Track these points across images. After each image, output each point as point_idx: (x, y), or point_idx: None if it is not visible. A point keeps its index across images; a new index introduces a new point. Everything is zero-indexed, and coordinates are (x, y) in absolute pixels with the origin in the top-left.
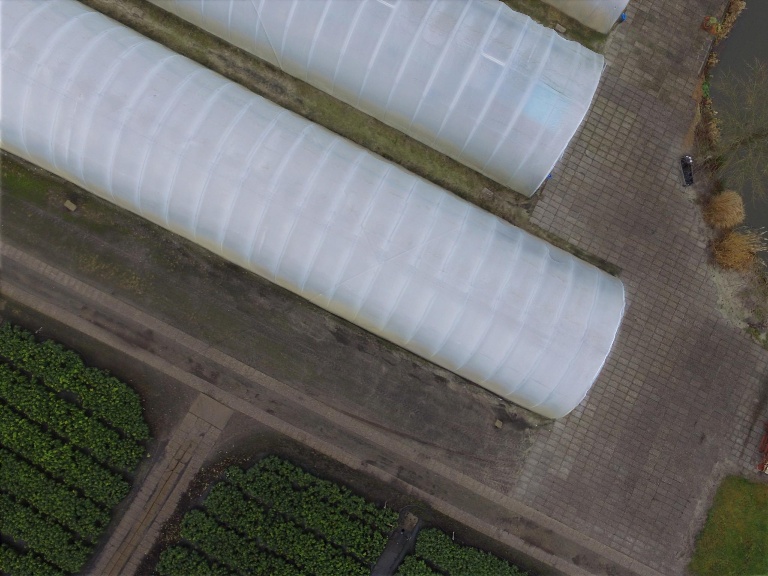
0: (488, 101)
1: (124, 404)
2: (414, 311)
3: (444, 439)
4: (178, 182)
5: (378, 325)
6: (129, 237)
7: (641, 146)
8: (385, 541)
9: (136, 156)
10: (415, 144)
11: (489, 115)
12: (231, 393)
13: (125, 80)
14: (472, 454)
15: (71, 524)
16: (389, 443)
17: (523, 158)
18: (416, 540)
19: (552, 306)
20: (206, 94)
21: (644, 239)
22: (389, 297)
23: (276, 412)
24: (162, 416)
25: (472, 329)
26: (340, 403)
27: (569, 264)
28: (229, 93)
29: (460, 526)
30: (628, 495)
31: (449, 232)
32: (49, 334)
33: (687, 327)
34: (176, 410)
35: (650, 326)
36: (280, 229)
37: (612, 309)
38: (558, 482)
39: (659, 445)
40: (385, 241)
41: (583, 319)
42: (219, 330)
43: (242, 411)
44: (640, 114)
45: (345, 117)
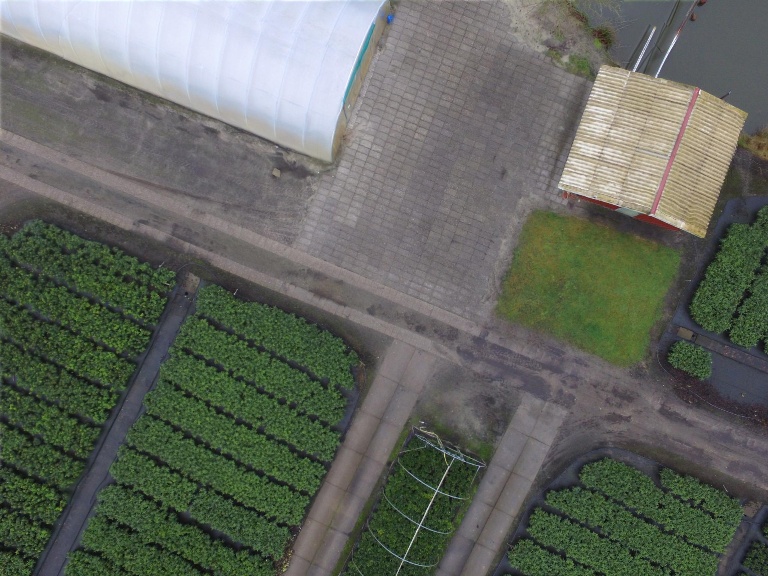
0: None
1: None
2: (147, 34)
3: (218, 192)
4: None
5: (124, 65)
6: None
7: None
8: (163, 301)
9: None
10: None
11: None
12: None
13: None
14: (250, 206)
15: None
16: (160, 200)
17: None
18: (196, 298)
19: (292, 12)
20: None
21: None
22: (118, 20)
23: (39, 176)
24: None
25: (209, 47)
26: (105, 162)
27: None
28: None
29: (243, 282)
30: (424, 239)
31: None
32: None
33: (478, 55)
34: None
35: (436, 57)
36: None
37: (364, 14)
38: (346, 230)
39: (455, 184)
40: None
41: (327, 23)
42: None
43: (4, 178)
44: None
45: None
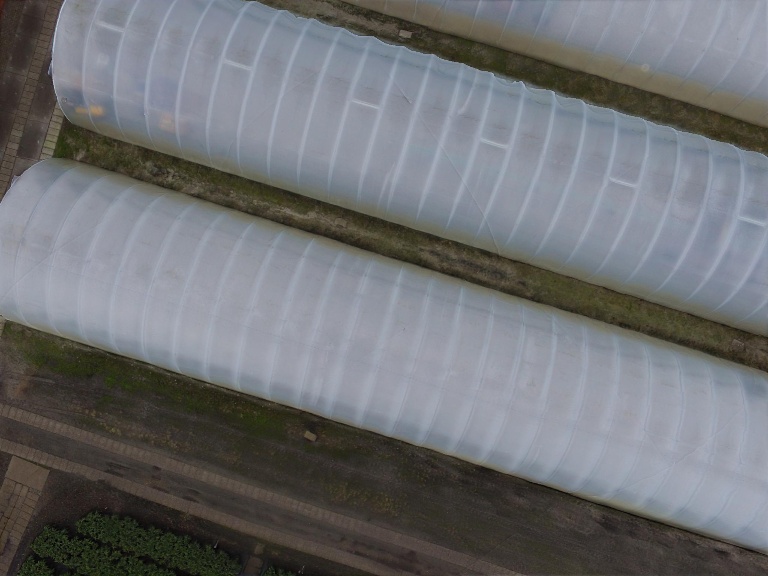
0: (751, 266)
1: None
2: (710, 507)
3: None
4: (441, 414)
5: (661, 518)
6: (374, 458)
7: None
8: None
9: (395, 395)
10: (651, 307)
11: (752, 279)
12: None
13: (371, 319)
14: None
15: None
16: None
17: None
18: None
19: None
20: (450, 313)
21: None
22: (681, 497)
23: None
24: None
25: None
26: None
27: None
28: (466, 302)
29: None
30: None
31: (735, 416)
32: (312, 571)
33: None
34: None
35: None
36: (556, 445)
37: None
38: None
39: None
40: (673, 442)
41: None
42: (483, 540)
43: None
44: None
45: (572, 292)
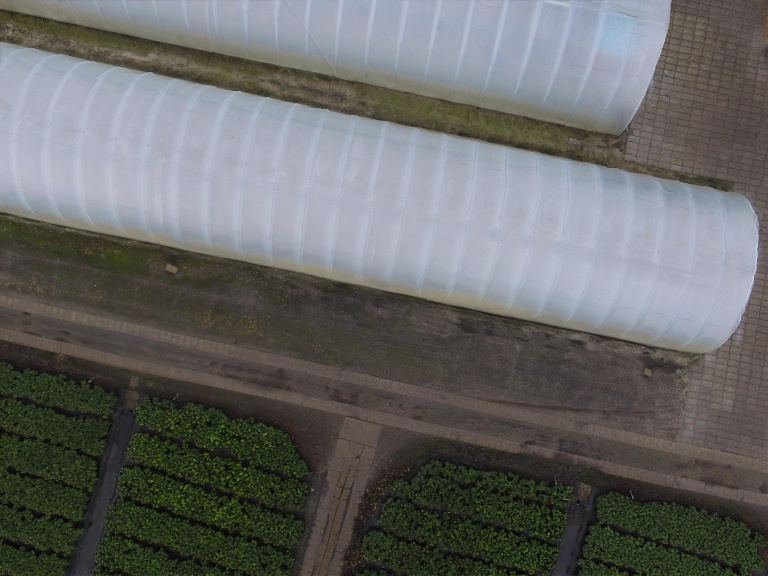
0: (562, 47)
1: (277, 446)
2: (542, 281)
3: (597, 401)
4: (277, 216)
5: (505, 305)
6: (235, 284)
7: (721, 50)
8: (565, 516)
9: (230, 202)
10: (488, 114)
11: (565, 62)
12: (375, 410)
13: (200, 130)
14: (629, 409)
15: (259, 573)
16: (543, 419)
17: (609, 96)
18: (596, 508)
19: (684, 238)
20: (279, 122)
21: (749, 145)
22: (514, 274)
23: (423, 417)
24: (315, 449)
25: (607, 284)
26: (484, 392)
27: (685, 191)
28: (298, 115)
29: (636, 483)
30: None
31: (557, 192)
32: (186, 398)
33: None
34: (326, 440)
35: None
36: (389, 235)
37: (745, 225)
38: (724, 415)
39: None
40: (497, 219)
41: (719, 243)
42: (346, 351)
43: (390, 424)
44: (711, 17)
45: (411, 107)
